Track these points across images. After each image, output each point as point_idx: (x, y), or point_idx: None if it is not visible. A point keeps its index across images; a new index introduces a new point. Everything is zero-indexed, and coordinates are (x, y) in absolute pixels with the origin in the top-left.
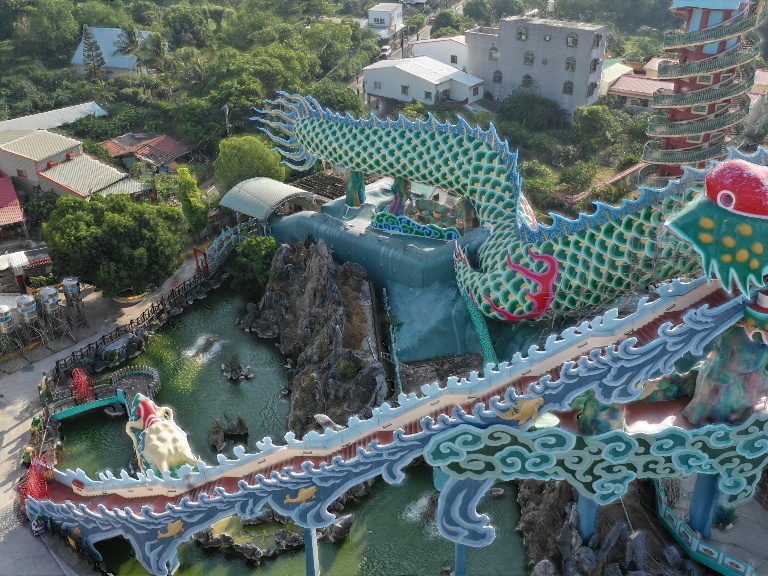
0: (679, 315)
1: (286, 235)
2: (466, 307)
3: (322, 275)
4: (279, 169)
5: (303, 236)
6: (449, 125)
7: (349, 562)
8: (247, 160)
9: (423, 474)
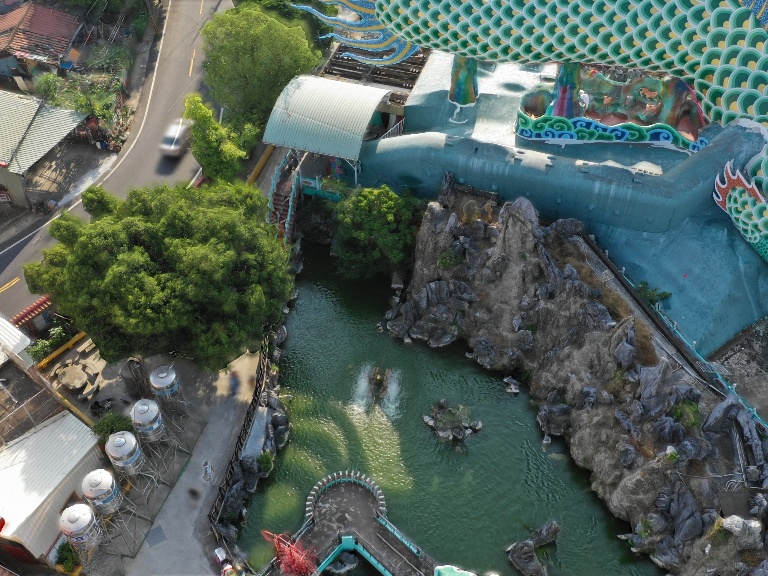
0: None
1: (393, 174)
2: (763, 257)
3: (525, 248)
4: (311, 56)
5: (434, 176)
6: None
7: None
8: (265, 54)
9: None
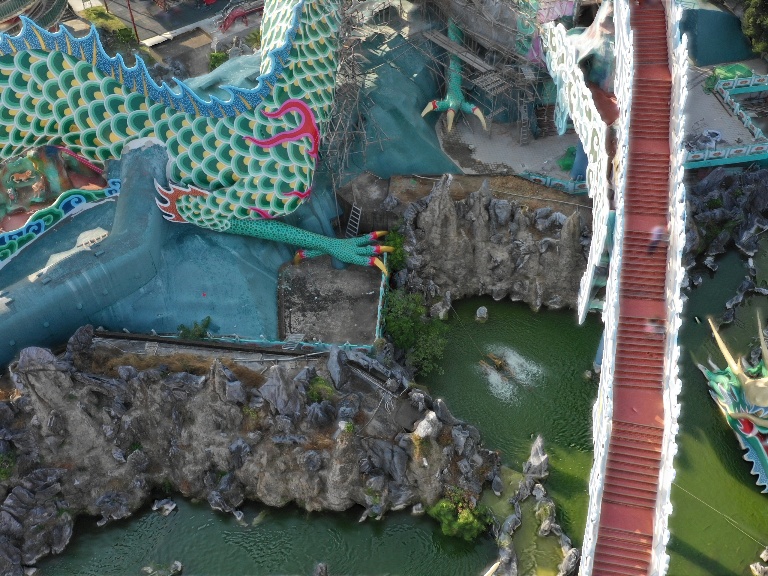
0: (634, 5)
1: None
2: (243, 234)
3: (65, 388)
4: None
5: None
6: None
7: (577, 462)
8: None
9: (454, 370)
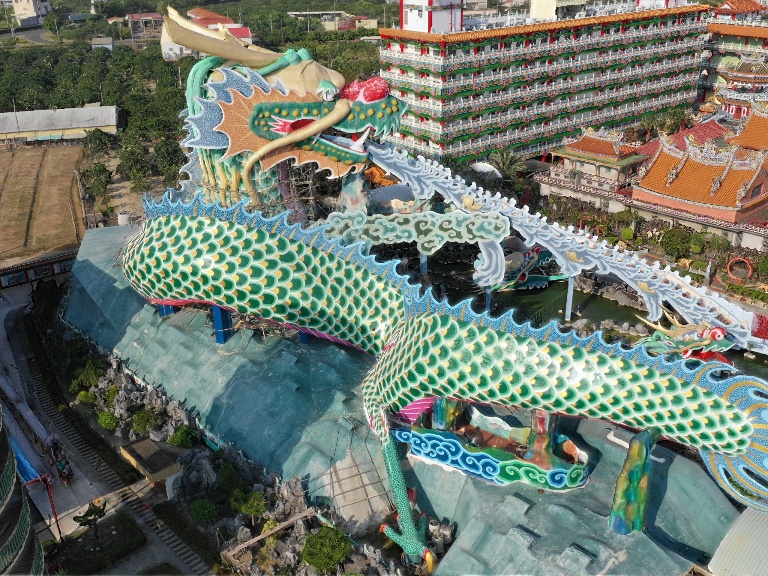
0: None
1: None
2: None
3: None
4: None
5: None
6: (484, 315)
7: None
8: None
9: None
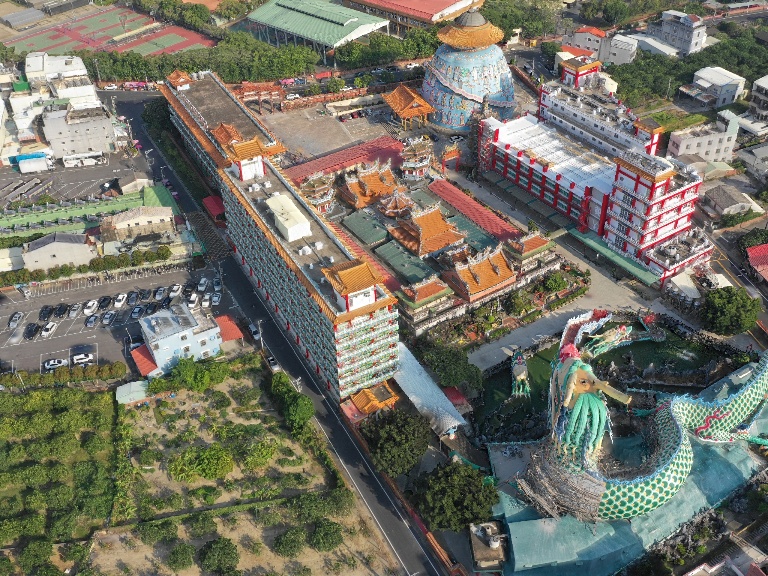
0: None
1: None
2: None
3: None
4: None
5: None
6: (760, 375)
7: None
8: None
9: None
